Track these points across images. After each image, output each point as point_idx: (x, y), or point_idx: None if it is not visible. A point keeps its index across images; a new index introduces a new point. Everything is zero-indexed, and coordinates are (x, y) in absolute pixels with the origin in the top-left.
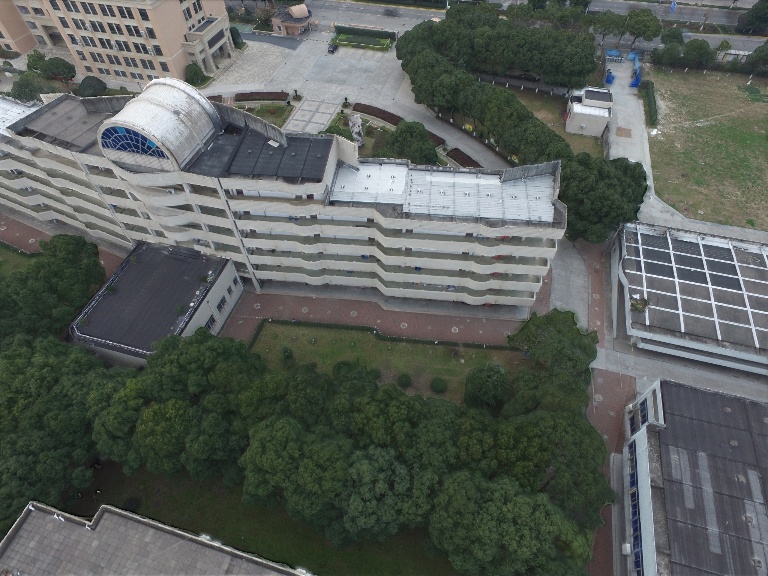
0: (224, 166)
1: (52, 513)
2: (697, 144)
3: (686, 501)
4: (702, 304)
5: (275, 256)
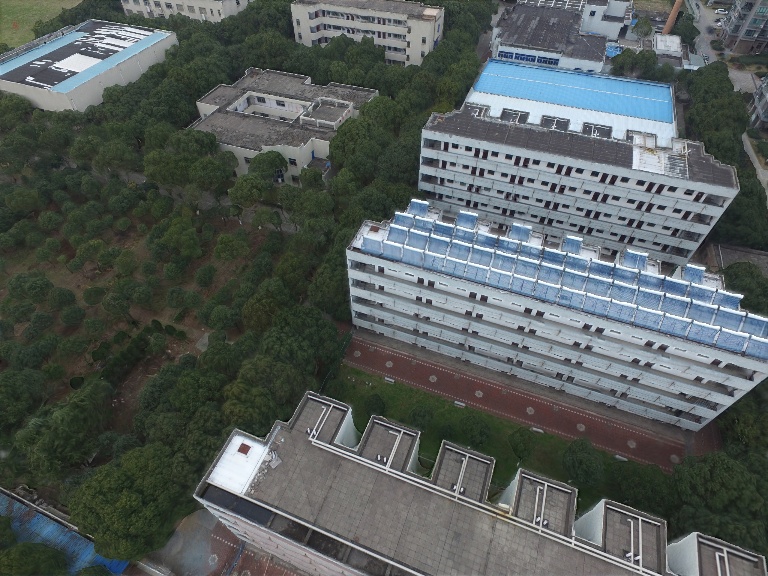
0: None
1: None
2: None
3: None
4: None
5: None
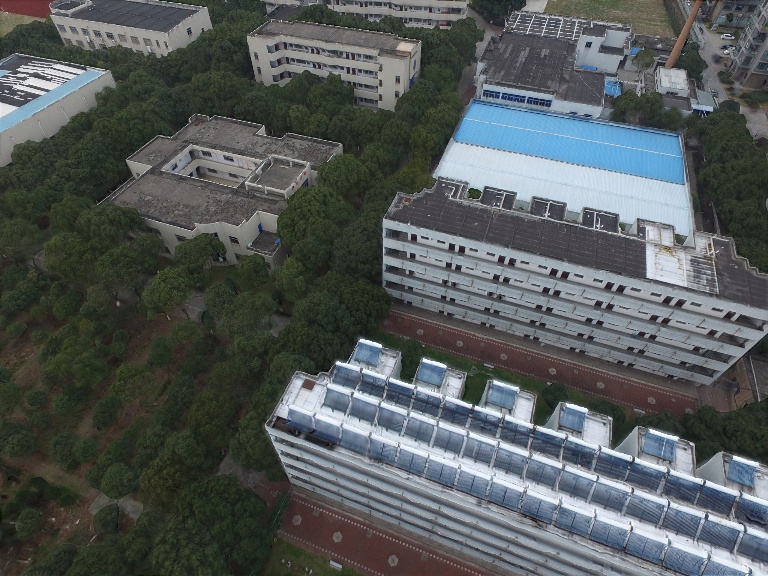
0: None
1: (278, 22)
2: (574, 3)
3: (500, 51)
4: (539, 30)
5: (346, 6)
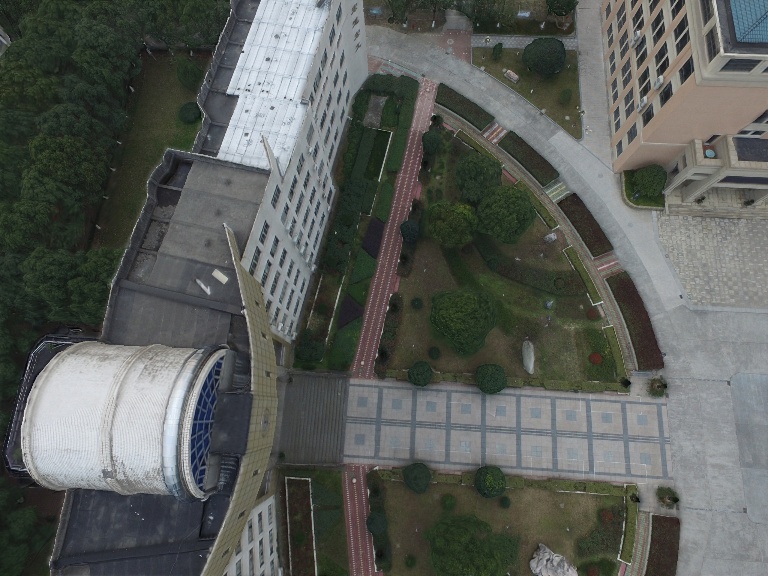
0: (99, 552)
1: None
2: None
3: None
4: None
5: None
